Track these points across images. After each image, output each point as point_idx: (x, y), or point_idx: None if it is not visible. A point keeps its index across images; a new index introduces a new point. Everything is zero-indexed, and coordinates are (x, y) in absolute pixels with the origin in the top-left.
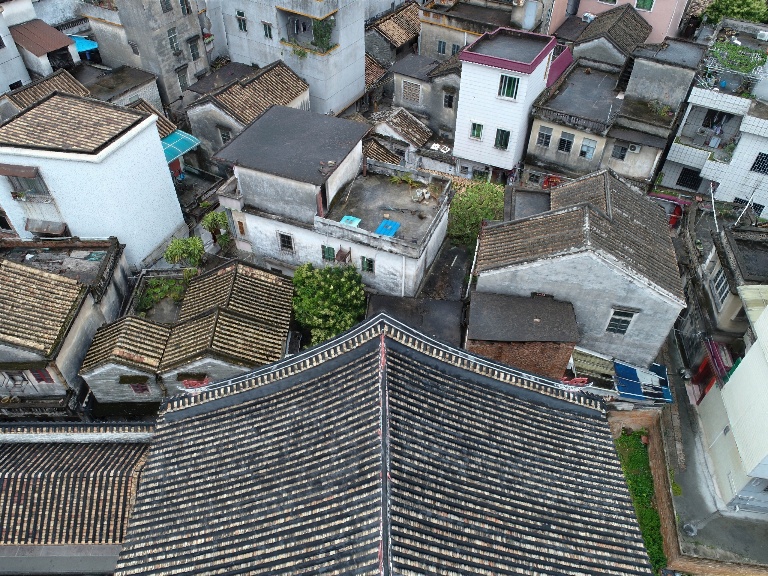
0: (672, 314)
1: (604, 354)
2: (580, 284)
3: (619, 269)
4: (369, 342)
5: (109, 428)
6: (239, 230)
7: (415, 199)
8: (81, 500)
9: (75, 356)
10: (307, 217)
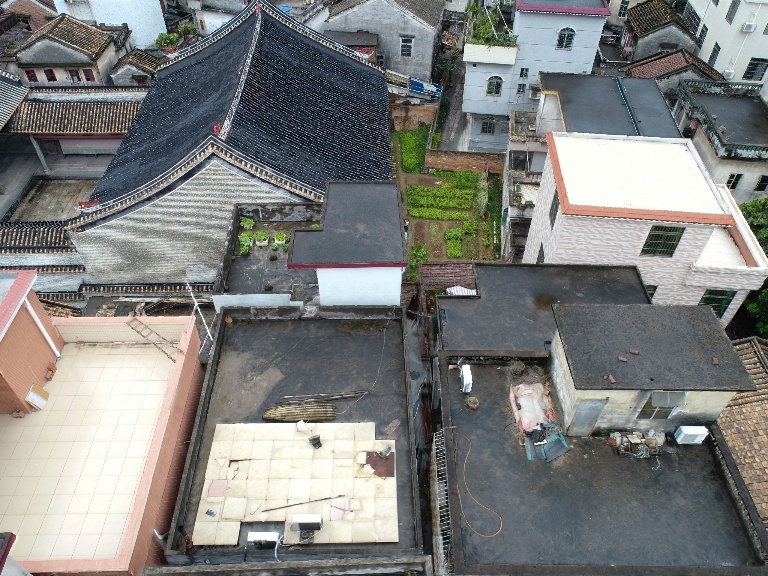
0: (430, 37)
1: (405, 74)
2: (380, 21)
3: (396, 7)
4: (254, 14)
5: (127, 89)
6: (201, 27)
7: (305, 3)
8: (114, 114)
9: (106, 71)
10: (239, 8)
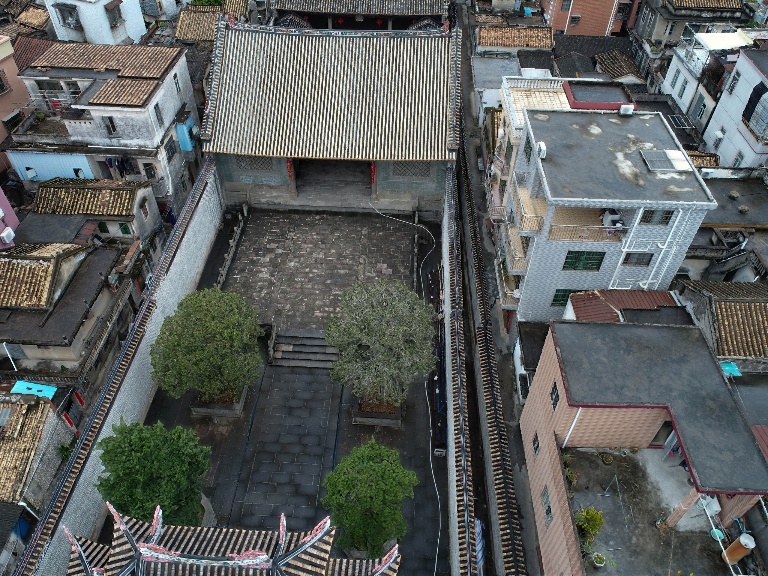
0: None
1: None
2: None
3: None
4: None
5: (269, 21)
6: (159, 9)
7: None
8: None
9: None
10: None
